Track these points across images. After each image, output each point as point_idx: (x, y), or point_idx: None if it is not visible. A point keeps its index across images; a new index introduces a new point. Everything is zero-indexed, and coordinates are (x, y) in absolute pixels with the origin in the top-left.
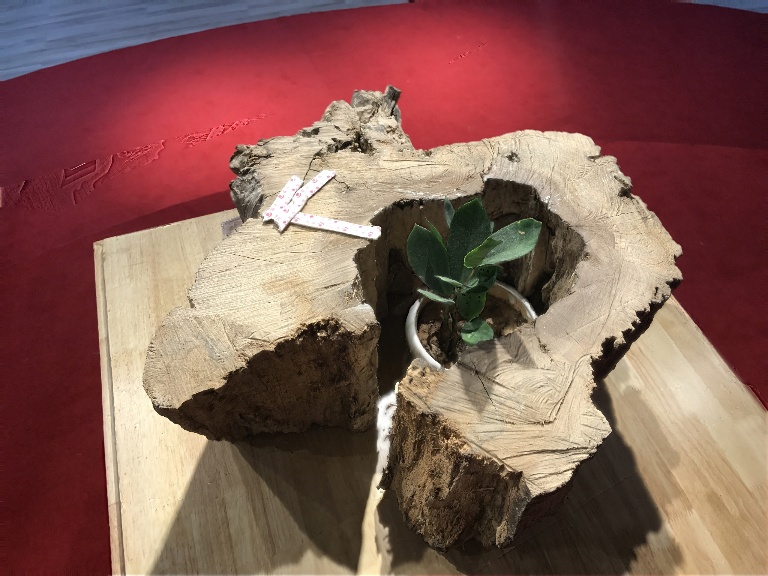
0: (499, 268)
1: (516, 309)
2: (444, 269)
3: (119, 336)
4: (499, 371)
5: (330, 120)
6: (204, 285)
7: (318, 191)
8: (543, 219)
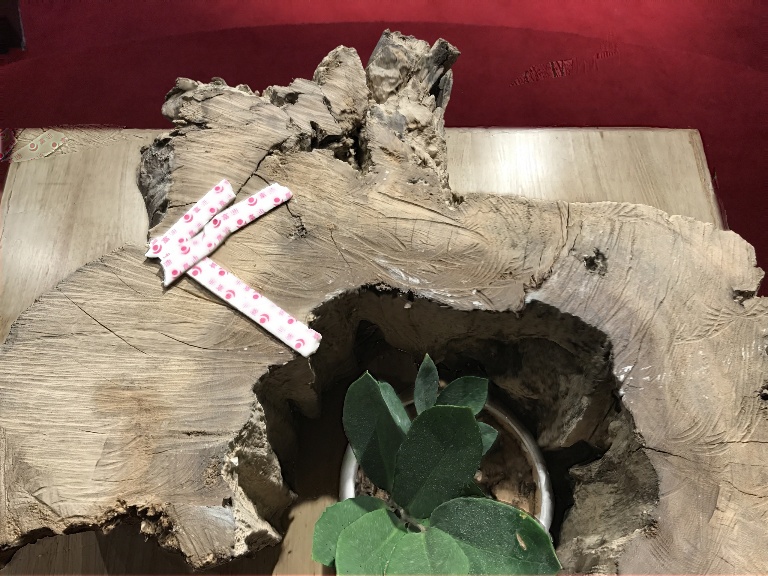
0: None
1: (527, 459)
2: None
3: (0, 291)
4: None
5: (322, 83)
6: (12, 355)
7: (252, 222)
8: (610, 382)
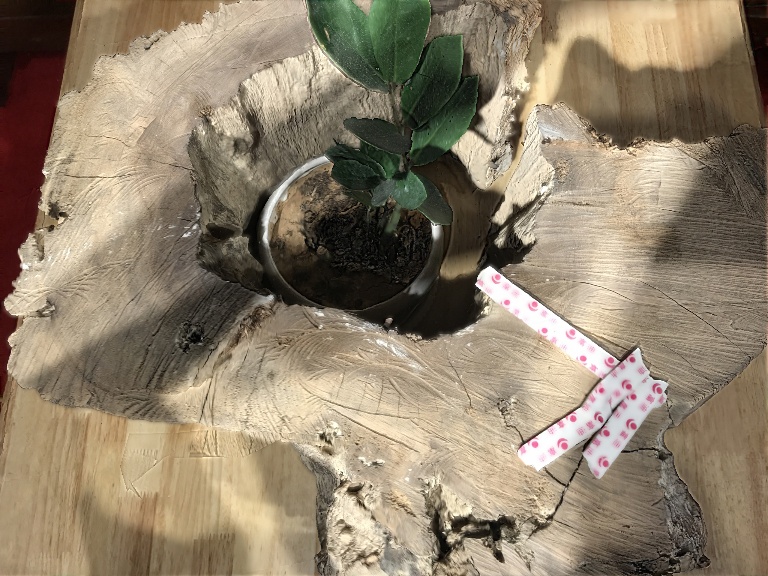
0: None
1: None
2: None
3: None
4: None
5: None
6: (767, 286)
7: (560, 420)
8: None
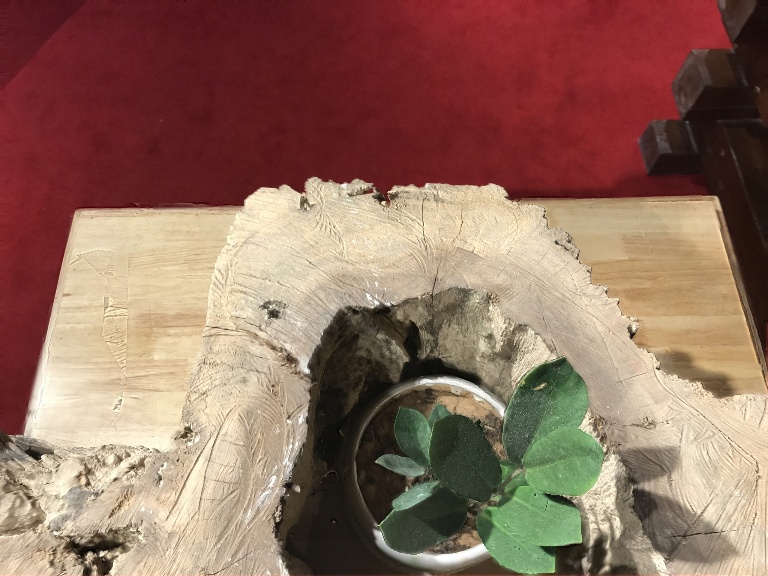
0: (479, 421)
1: (406, 394)
2: (443, 501)
3: None
4: (685, 503)
5: None
6: None
7: None
8: None
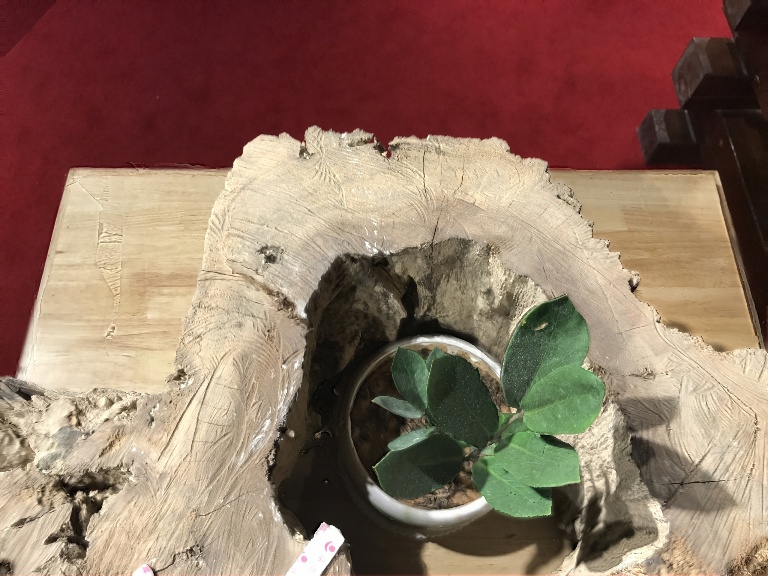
0: None
1: None
2: (438, 448)
3: None
4: (683, 452)
5: None
6: None
7: None
8: None
